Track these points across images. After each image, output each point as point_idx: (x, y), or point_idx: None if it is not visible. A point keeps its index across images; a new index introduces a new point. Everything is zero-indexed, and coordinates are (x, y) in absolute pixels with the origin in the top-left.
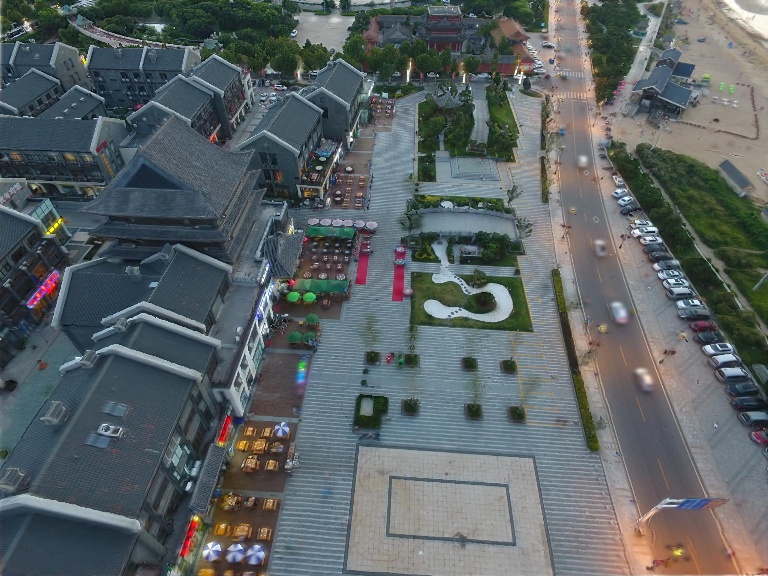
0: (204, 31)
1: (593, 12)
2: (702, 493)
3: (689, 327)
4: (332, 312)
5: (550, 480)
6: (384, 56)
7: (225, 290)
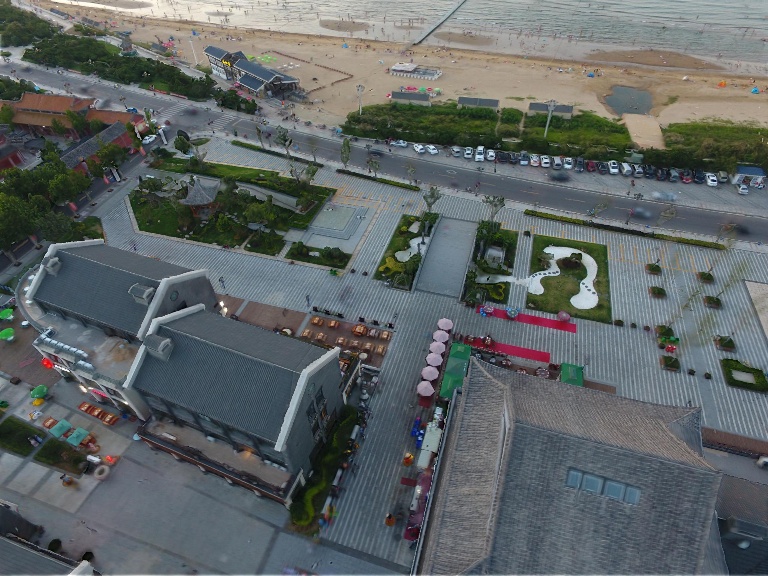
0: None
1: (51, 55)
2: (736, 216)
3: (589, 172)
4: None
5: (761, 277)
6: (12, 216)
7: None
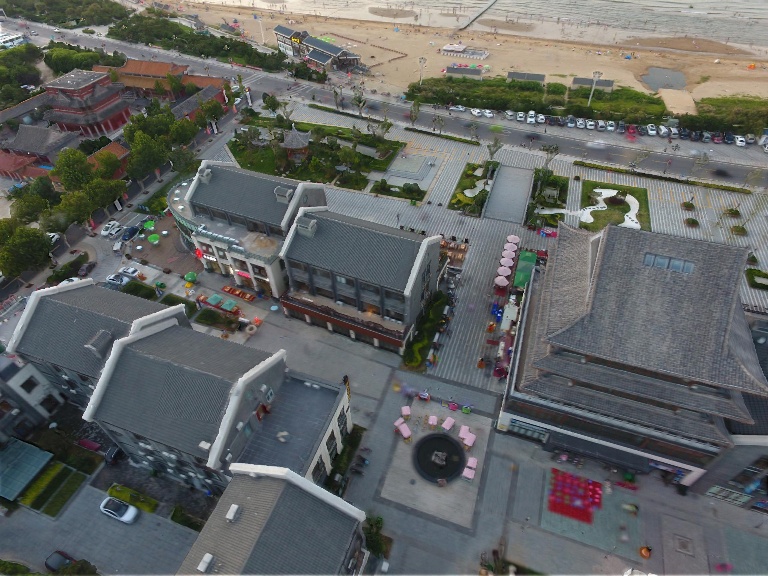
0: None
1: (133, 33)
2: (762, 169)
3: None
4: None
5: None
6: (148, 150)
7: None
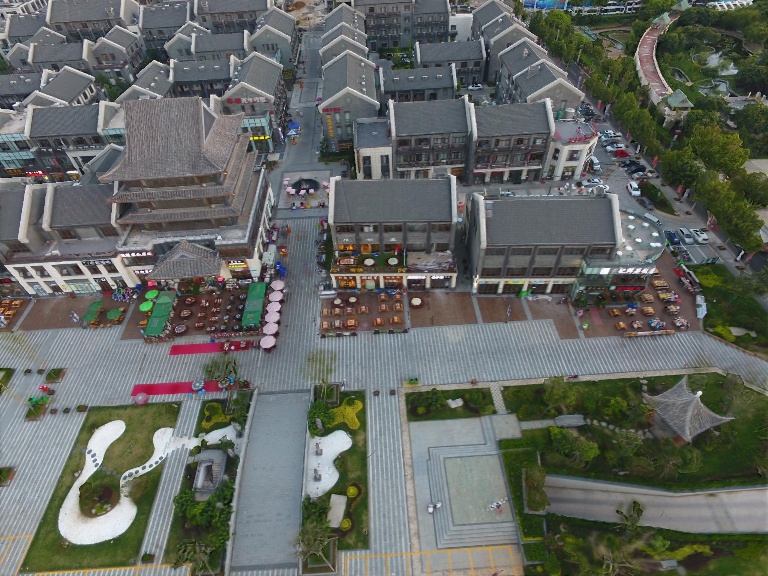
0: (752, 85)
1: None
2: None
3: None
4: (133, 332)
5: None
6: None
7: (113, 233)
